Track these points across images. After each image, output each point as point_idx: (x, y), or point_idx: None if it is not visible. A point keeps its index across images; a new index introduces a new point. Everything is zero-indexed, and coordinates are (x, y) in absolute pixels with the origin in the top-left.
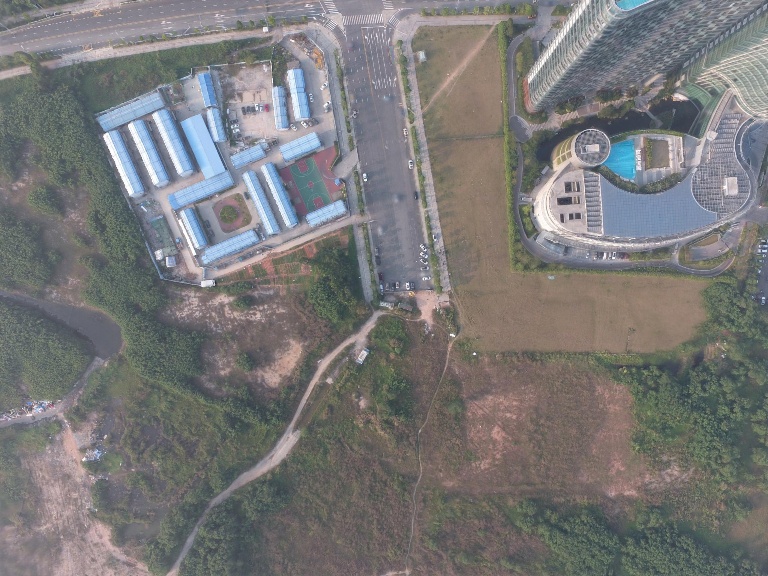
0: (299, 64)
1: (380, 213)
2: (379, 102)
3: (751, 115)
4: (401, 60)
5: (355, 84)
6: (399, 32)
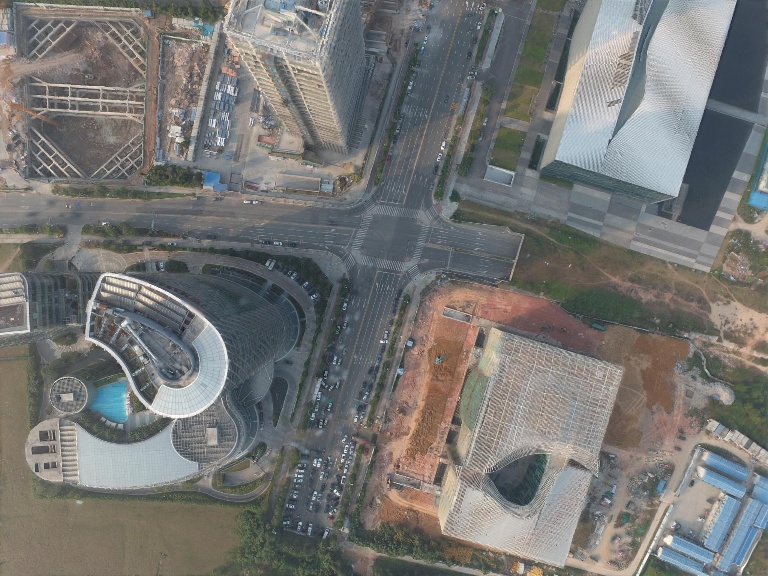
0: None
1: None
2: None
3: None
4: None
5: None
6: None
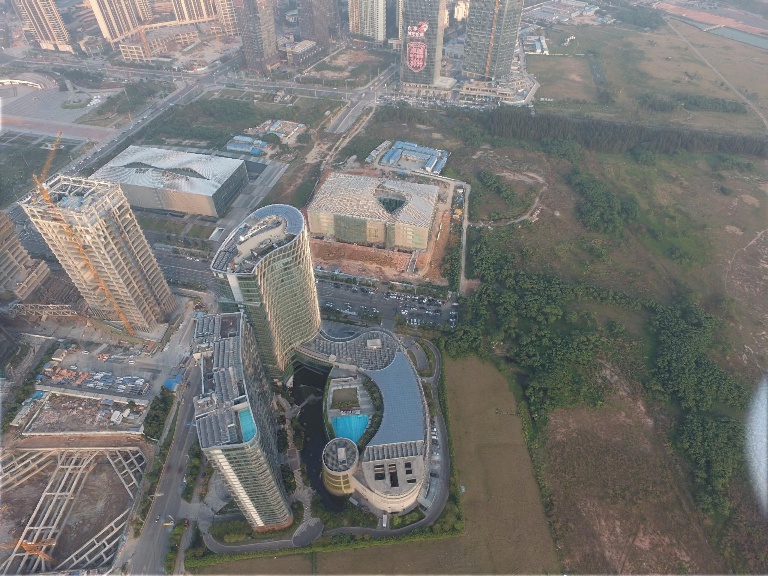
0: None
1: None
2: None
3: (317, 333)
4: None
5: None
6: None
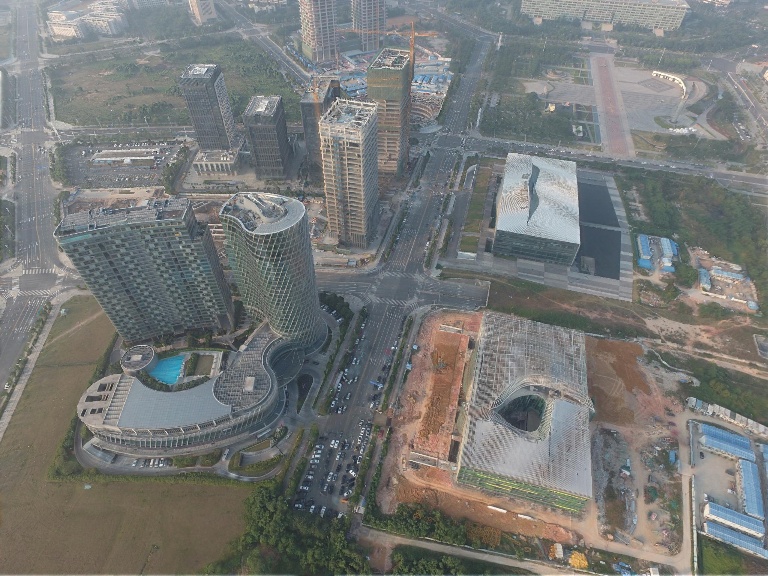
0: None
1: None
2: (11, 342)
3: (281, 335)
4: (40, 313)
5: (0, 330)
6: (56, 299)
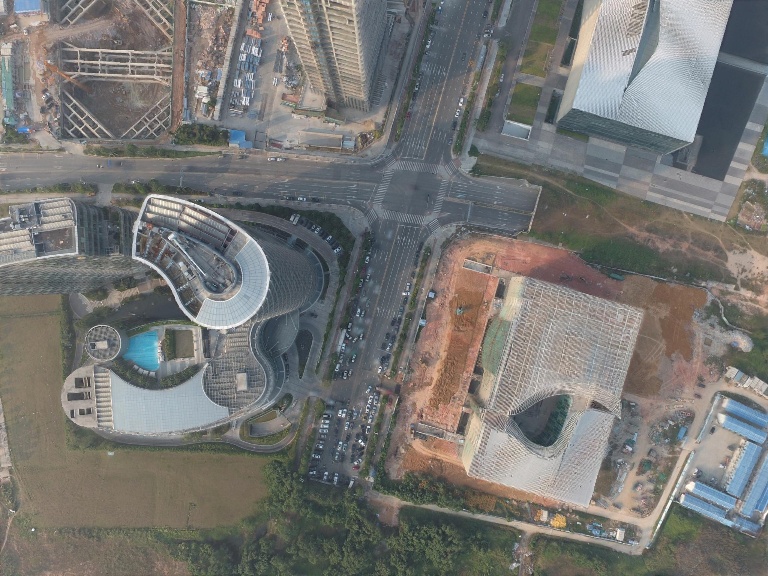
0: None
1: None
2: None
3: None
4: None
5: None
6: None
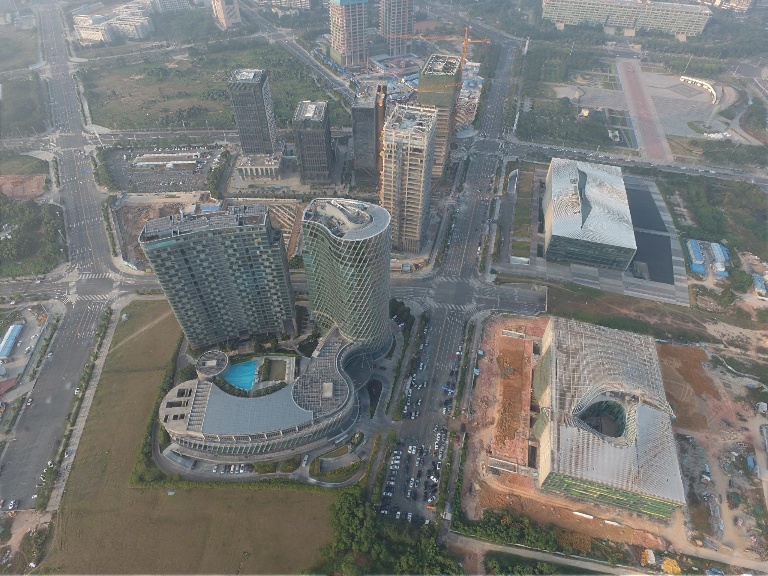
0: (24, 323)
1: (26, 432)
2: (76, 347)
3: (351, 340)
4: (103, 318)
5: (63, 335)
6: (116, 304)
